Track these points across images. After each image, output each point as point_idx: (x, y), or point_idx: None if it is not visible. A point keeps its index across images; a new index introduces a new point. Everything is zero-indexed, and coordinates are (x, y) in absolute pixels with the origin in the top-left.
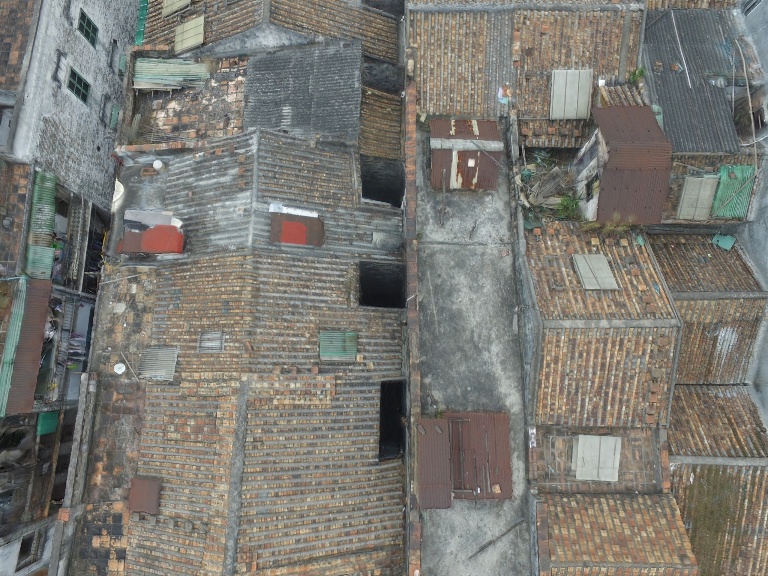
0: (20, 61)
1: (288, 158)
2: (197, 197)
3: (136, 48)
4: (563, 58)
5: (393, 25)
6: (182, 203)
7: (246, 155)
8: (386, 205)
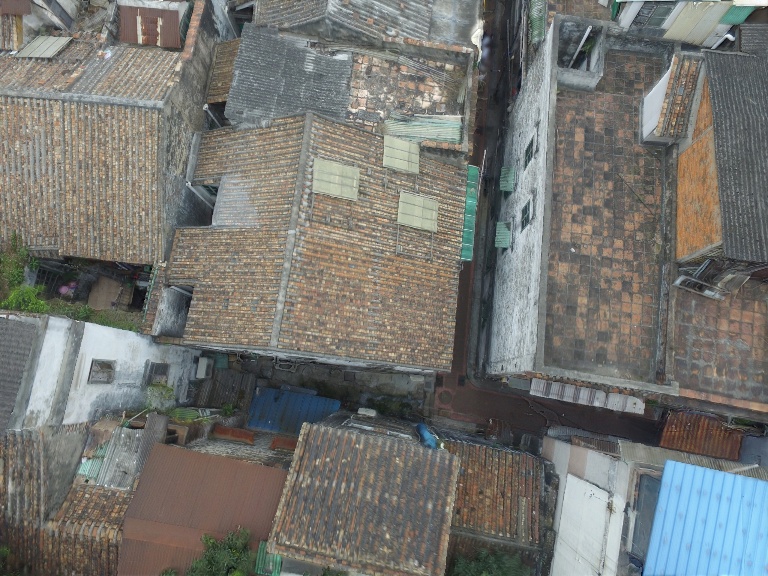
0: (572, 130)
1: (307, 6)
2: (395, 0)
3: (457, 146)
4: (38, 68)
5: (198, 172)
6: (412, 5)
7: (341, 2)
8: (239, 6)
